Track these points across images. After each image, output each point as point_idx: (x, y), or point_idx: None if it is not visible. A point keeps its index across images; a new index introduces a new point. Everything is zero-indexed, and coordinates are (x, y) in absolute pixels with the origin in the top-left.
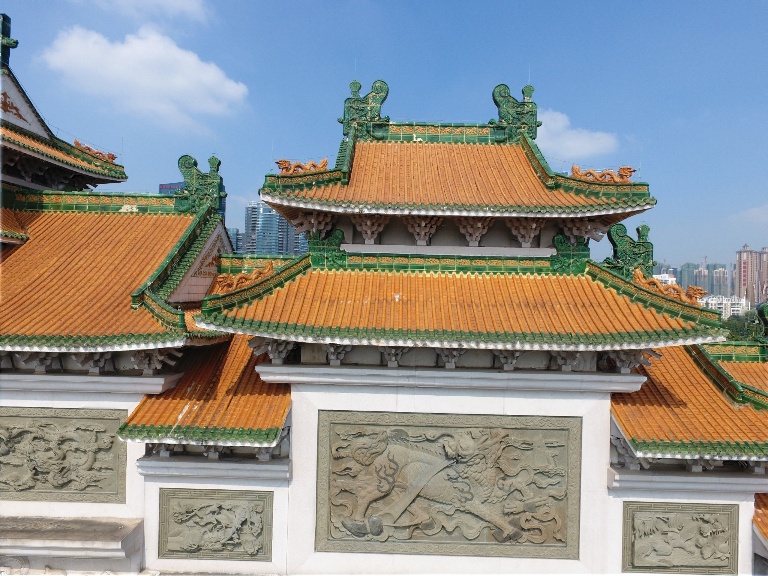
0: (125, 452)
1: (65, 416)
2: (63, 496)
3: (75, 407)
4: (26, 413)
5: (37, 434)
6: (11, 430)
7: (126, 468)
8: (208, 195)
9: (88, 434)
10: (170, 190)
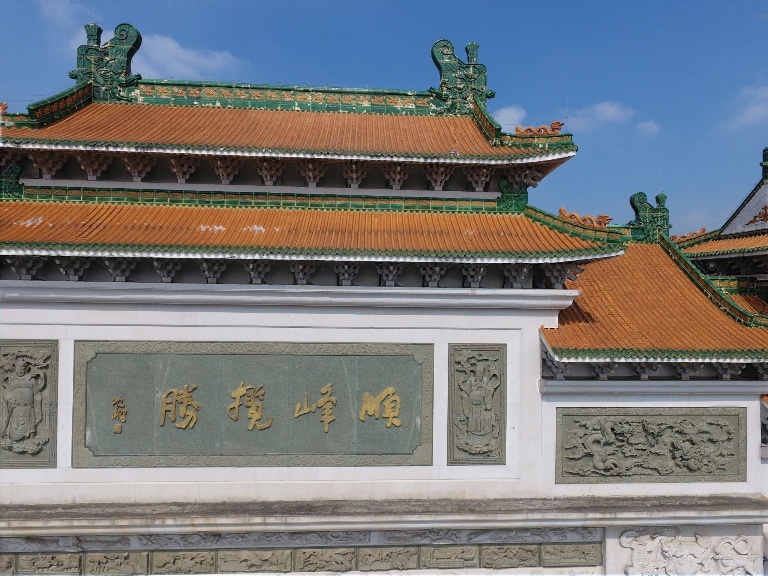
0: (744, 441)
1: (698, 414)
2: (697, 478)
3: (707, 406)
4: (667, 412)
5: (679, 429)
6: (658, 426)
7: (747, 454)
8: (660, 226)
9: (714, 427)
10: (625, 222)
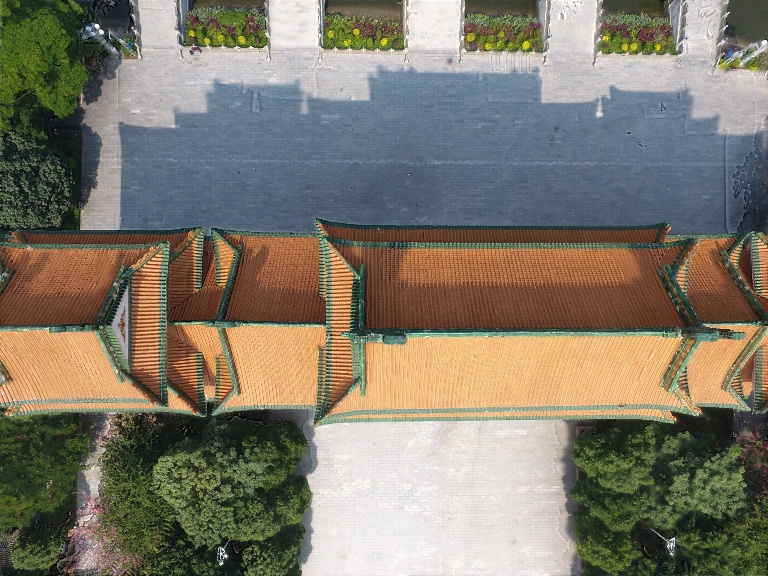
0: None
1: None
2: None
3: None
4: None
5: None
6: None
7: None
8: None
9: None
10: None
